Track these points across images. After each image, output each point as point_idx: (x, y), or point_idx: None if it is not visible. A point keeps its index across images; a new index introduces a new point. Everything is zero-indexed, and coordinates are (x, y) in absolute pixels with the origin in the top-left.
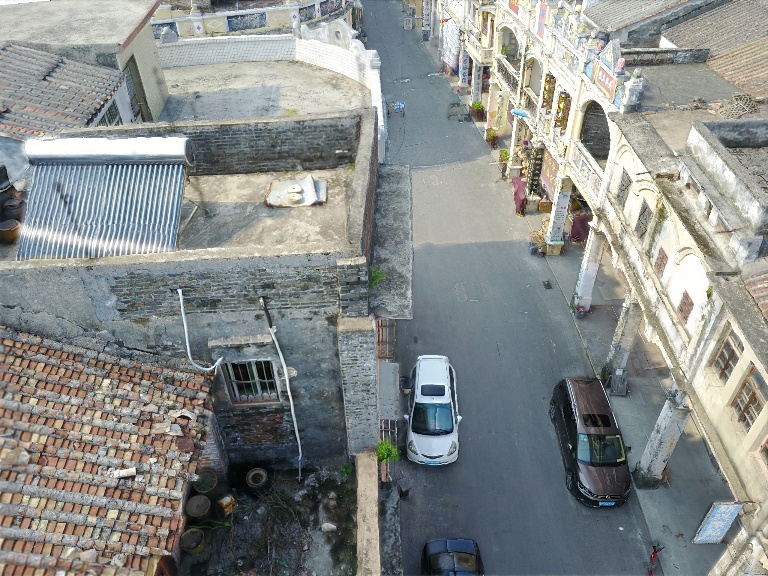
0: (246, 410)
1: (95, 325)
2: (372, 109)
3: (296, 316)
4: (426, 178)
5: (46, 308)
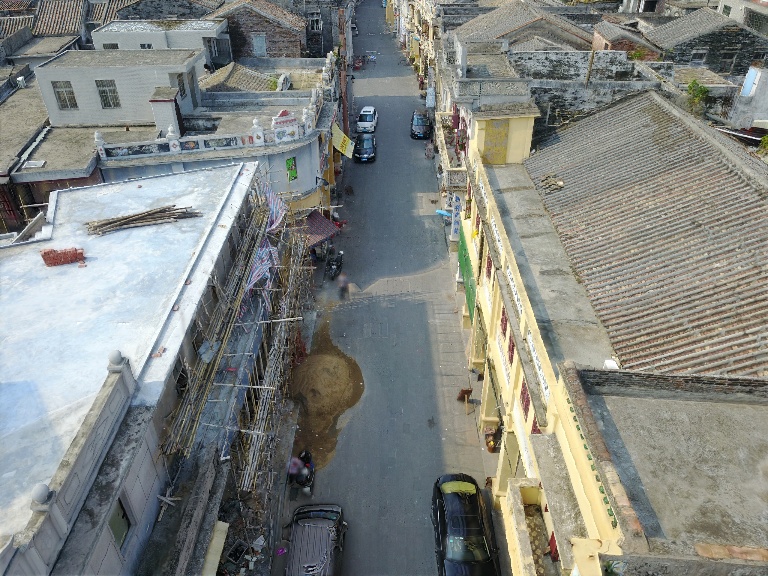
0: (313, 34)
1: (288, 7)
2: None
3: (324, 7)
4: (381, 80)
5: (281, 2)
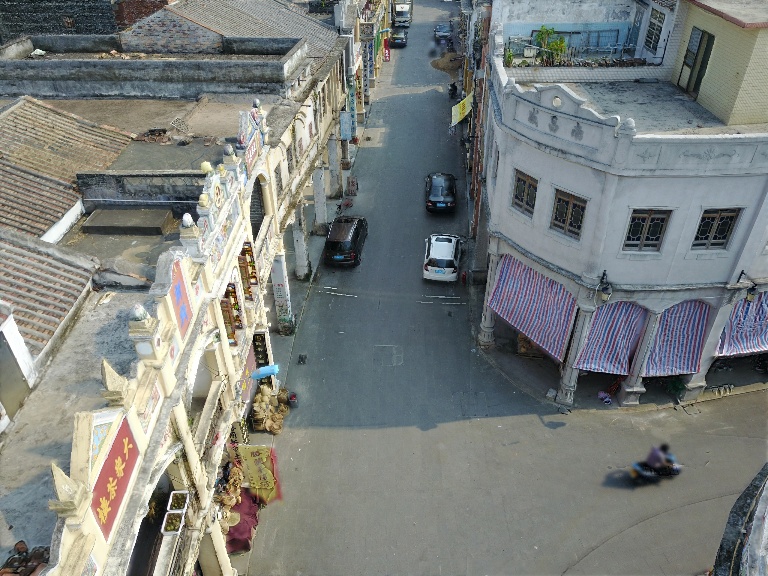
0: None
1: None
2: None
3: None
4: None
5: None
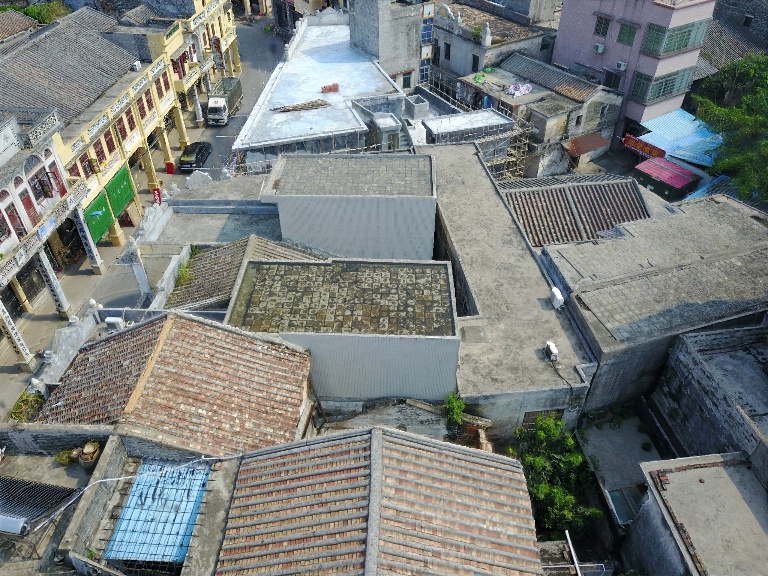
0: None
1: None
2: None
3: None
4: None
5: None
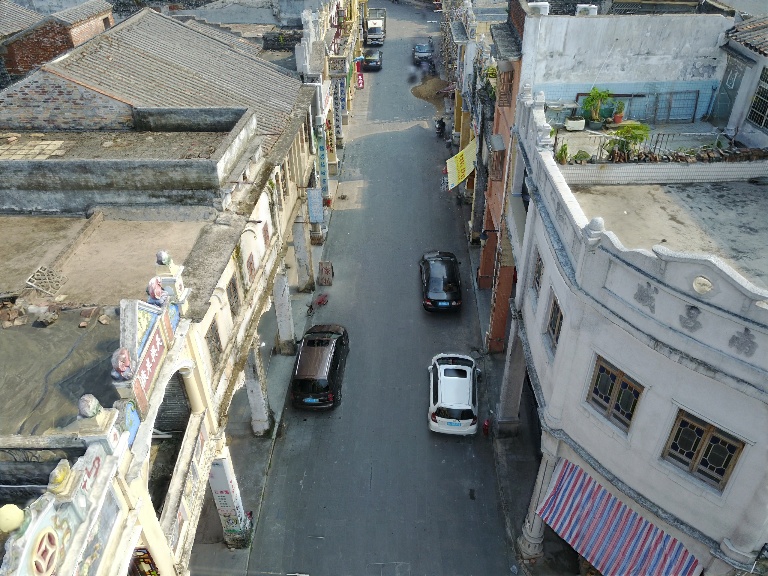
0: None
1: None
2: (529, 13)
3: None
4: None
5: None
